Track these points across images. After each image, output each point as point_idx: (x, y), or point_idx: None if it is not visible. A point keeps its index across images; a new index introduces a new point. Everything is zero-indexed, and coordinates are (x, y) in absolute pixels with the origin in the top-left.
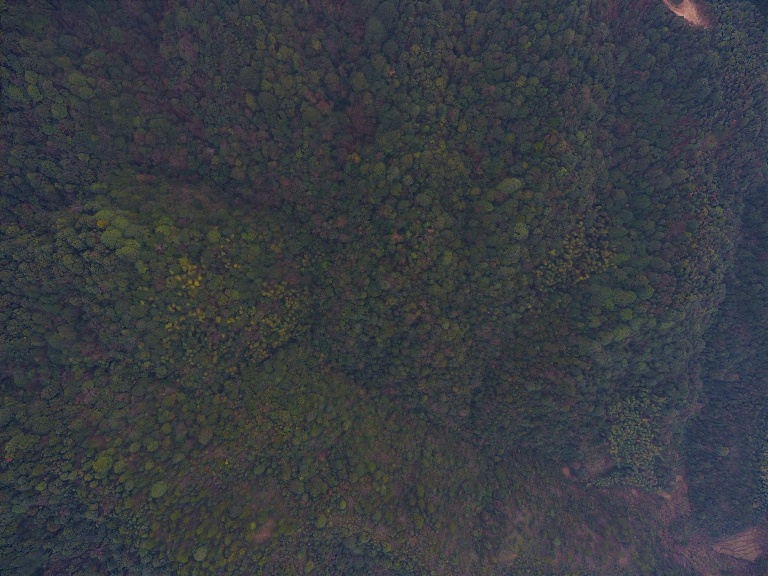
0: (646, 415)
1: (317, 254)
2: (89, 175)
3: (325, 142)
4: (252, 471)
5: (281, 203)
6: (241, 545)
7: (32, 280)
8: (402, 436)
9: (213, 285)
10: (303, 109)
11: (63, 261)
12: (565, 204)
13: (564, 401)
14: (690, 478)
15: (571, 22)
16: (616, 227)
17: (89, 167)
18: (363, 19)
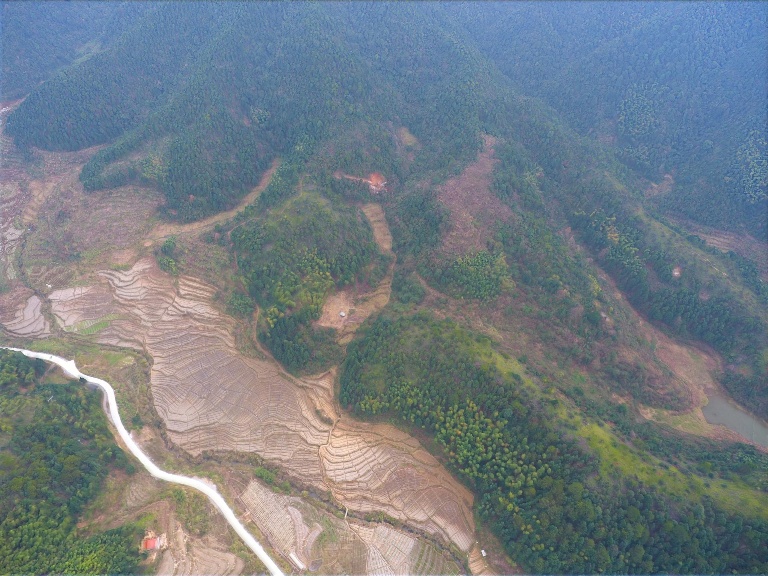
0: None
1: None
2: None
3: None
4: None
5: None
6: None
7: None
8: None
9: None
10: None
11: None
12: None
13: None
14: (678, 171)
15: None
16: None
17: None
18: None
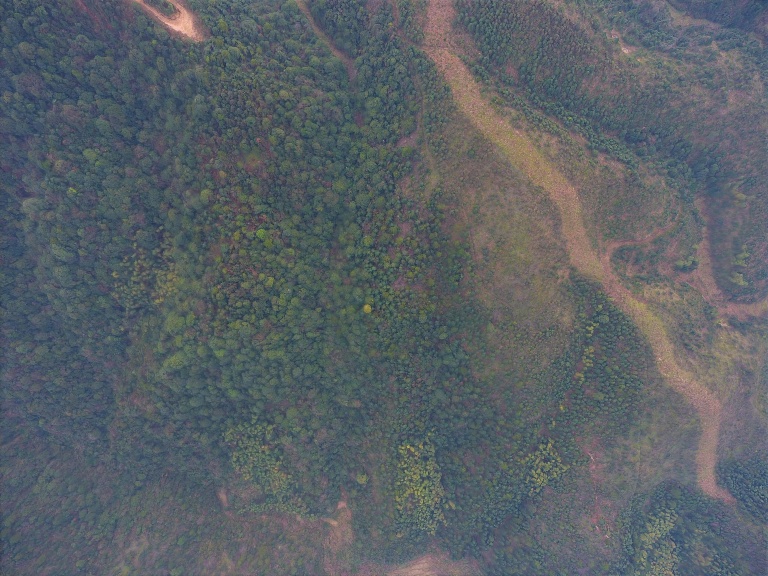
0: (267, 442)
1: None
2: None
3: None
4: None
5: None
6: None
7: None
8: (17, 461)
9: None
10: None
11: None
12: (99, 225)
13: (163, 428)
14: (348, 505)
15: (27, 35)
16: (174, 249)
17: None
18: None
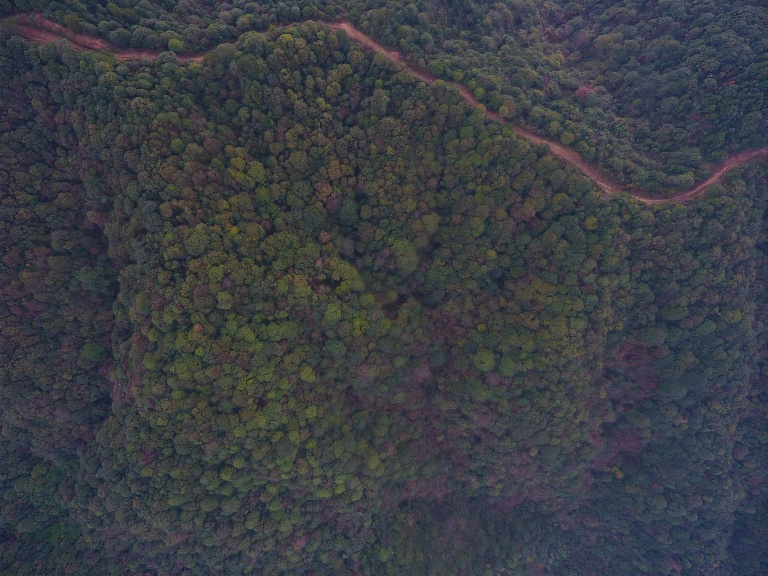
0: None
1: (559, 547)
2: (370, 536)
3: None
4: None
5: None
6: None
7: None
8: None
9: None
10: (585, 453)
11: None
12: None
13: None
14: None
15: None
16: None
17: (370, 528)
18: (661, 378)
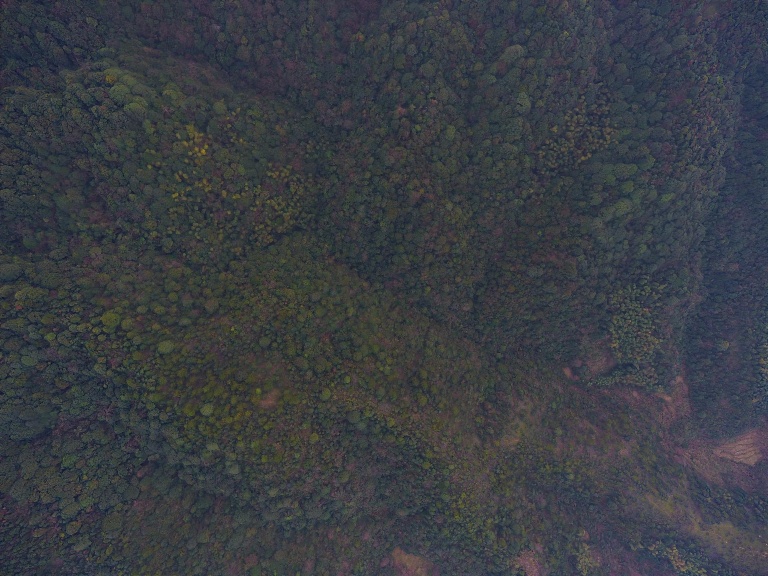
0: (647, 305)
1: (321, 142)
2: (97, 41)
3: (330, 20)
4: (257, 343)
5: (286, 90)
6: (247, 408)
7: (41, 136)
8: (405, 327)
9: (219, 155)
10: None
11: (72, 114)
12: (567, 74)
13: (566, 286)
14: (690, 378)
15: None
16: (617, 102)
17: (97, 33)
18: None
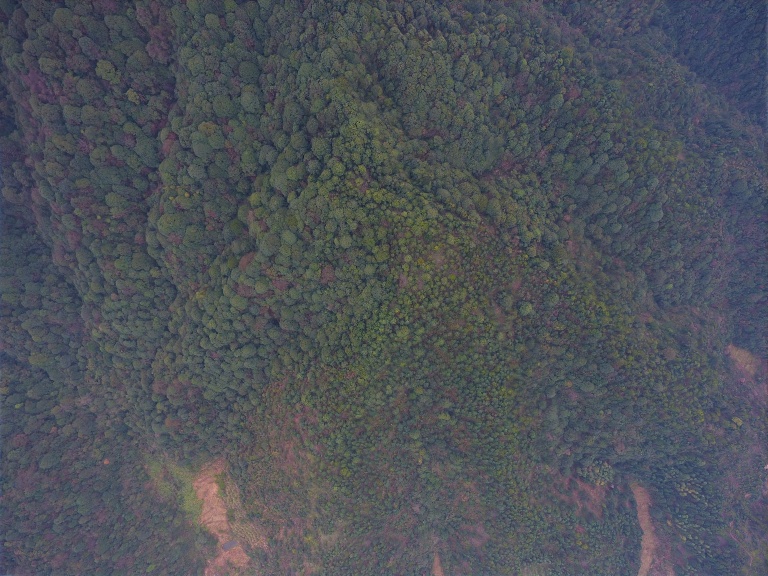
0: None
1: None
2: None
3: None
4: (658, 108)
5: None
6: None
7: None
8: None
9: None
10: None
11: None
12: None
13: None
14: None
15: None
16: None
17: None
18: None
